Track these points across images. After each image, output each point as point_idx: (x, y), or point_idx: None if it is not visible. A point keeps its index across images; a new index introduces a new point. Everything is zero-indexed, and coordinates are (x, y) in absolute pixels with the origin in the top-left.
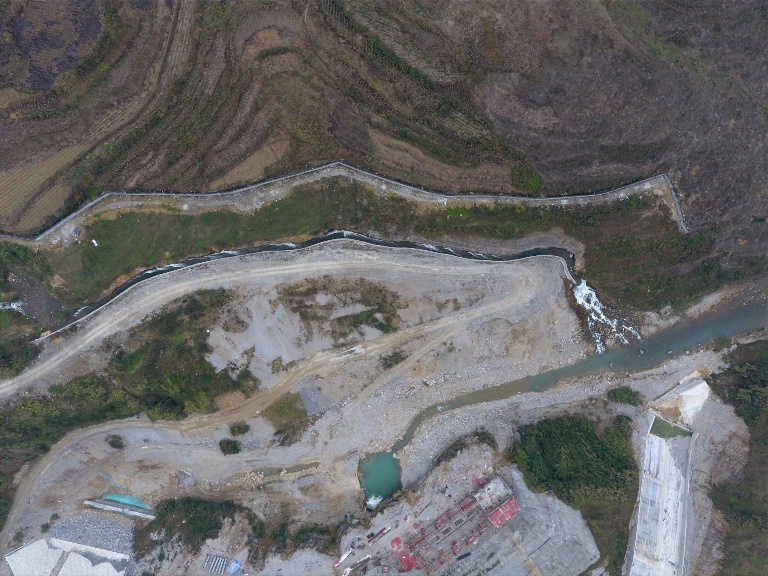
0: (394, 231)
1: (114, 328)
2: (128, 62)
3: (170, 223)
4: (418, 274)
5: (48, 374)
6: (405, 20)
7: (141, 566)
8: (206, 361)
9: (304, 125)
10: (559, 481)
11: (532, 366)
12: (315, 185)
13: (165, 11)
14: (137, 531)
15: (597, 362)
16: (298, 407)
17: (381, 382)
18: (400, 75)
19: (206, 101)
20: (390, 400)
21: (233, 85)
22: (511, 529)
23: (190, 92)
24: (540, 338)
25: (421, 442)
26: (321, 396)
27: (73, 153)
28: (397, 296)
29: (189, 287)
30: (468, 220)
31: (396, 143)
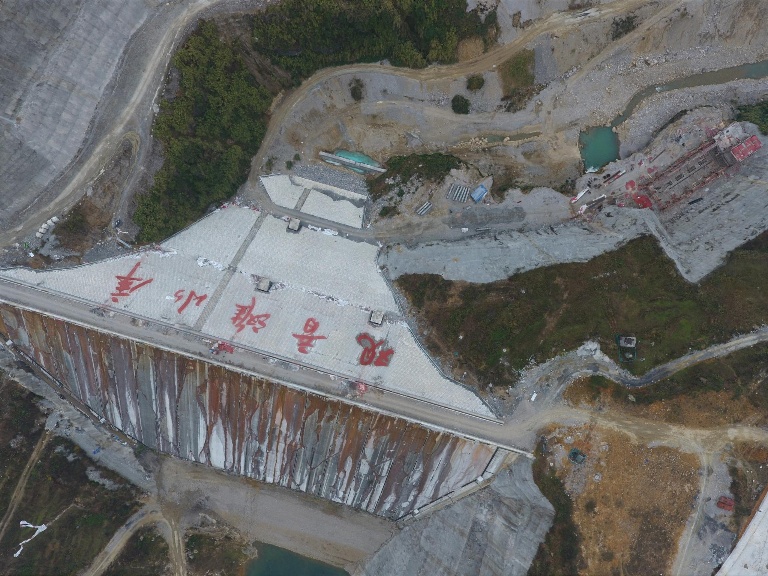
0: None
1: None
2: None
3: None
4: None
5: None
6: None
7: (379, 204)
8: None
9: None
10: None
11: (751, 52)
12: None
13: None
14: (370, 180)
15: None
16: (528, 71)
17: (608, 53)
18: None
19: None
20: (612, 76)
21: None
22: (744, 175)
23: None
24: None
25: (641, 116)
26: (552, 60)
27: None
28: None
29: None
30: None
31: None
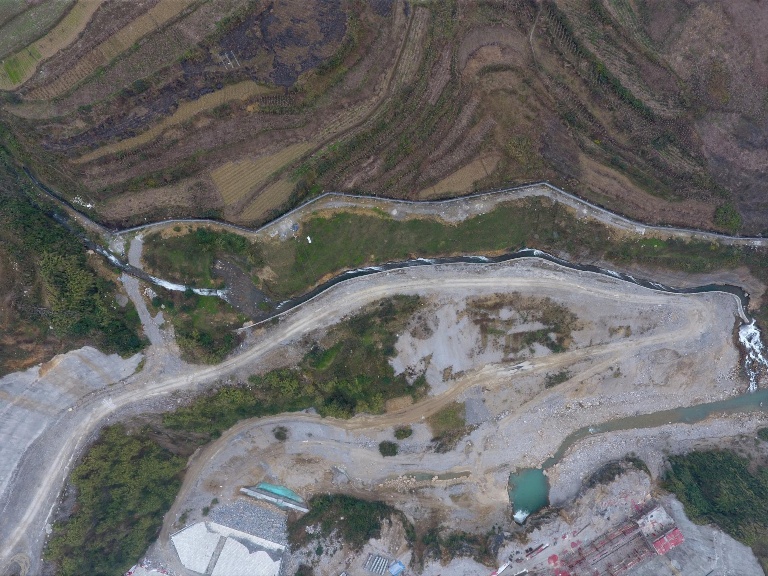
0: (586, 255)
1: (314, 324)
2: (365, 66)
3: (379, 227)
4: (600, 299)
5: (249, 364)
6: (633, 51)
7: (297, 558)
8: (388, 364)
9: (517, 143)
10: (724, 515)
11: (685, 398)
12: (518, 203)
13: (402, 19)
14: (291, 523)
15: (747, 400)
16: (459, 416)
17: (541, 399)
18: (622, 104)
19: (428, 111)
20: (545, 418)
21: (454, 97)
22: (667, 557)
23: (416, 101)
24: (703, 372)
25: (572, 462)
26: (483, 408)
27: (301, 150)
28: (575, 318)
29: (386, 291)
30: (661, 251)
31: (605, 170)
